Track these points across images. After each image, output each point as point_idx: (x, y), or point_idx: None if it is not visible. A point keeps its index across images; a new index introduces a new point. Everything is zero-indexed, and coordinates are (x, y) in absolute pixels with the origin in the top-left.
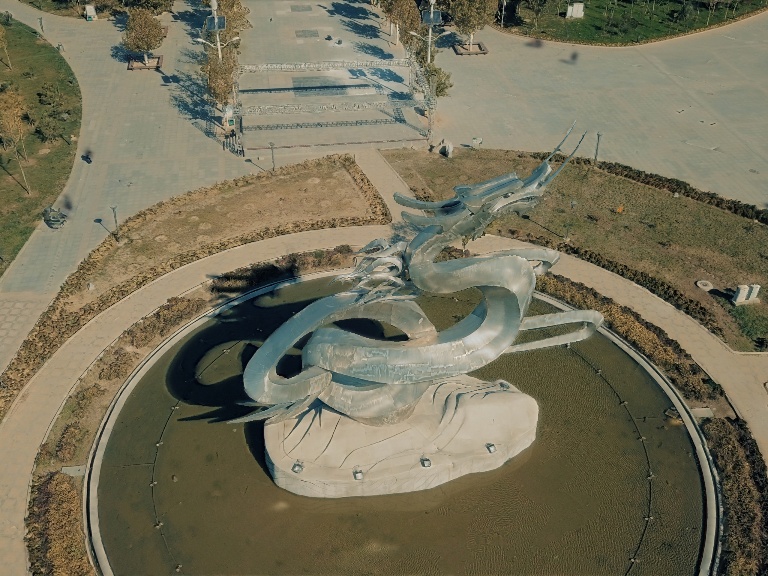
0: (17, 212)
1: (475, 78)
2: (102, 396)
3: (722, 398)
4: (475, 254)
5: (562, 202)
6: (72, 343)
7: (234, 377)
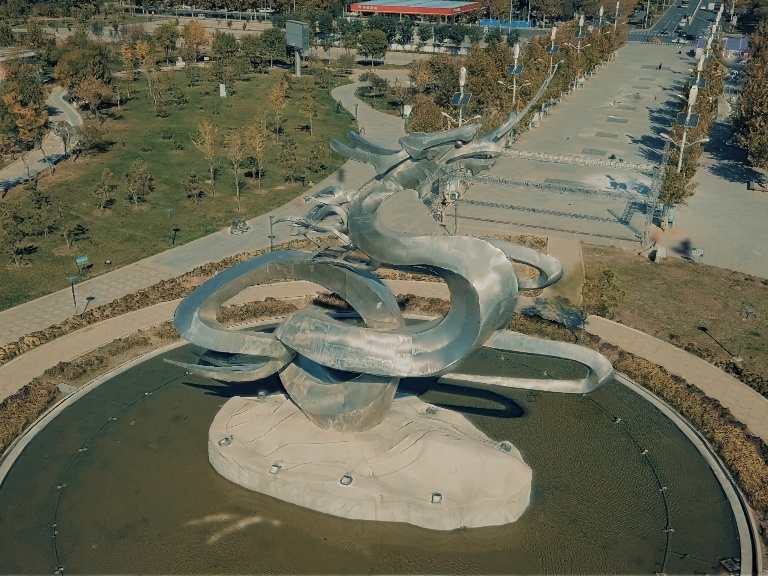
0: (217, 218)
1: (752, 210)
2: (144, 347)
3: None
4: (606, 343)
5: (764, 327)
6: (162, 306)
7: None
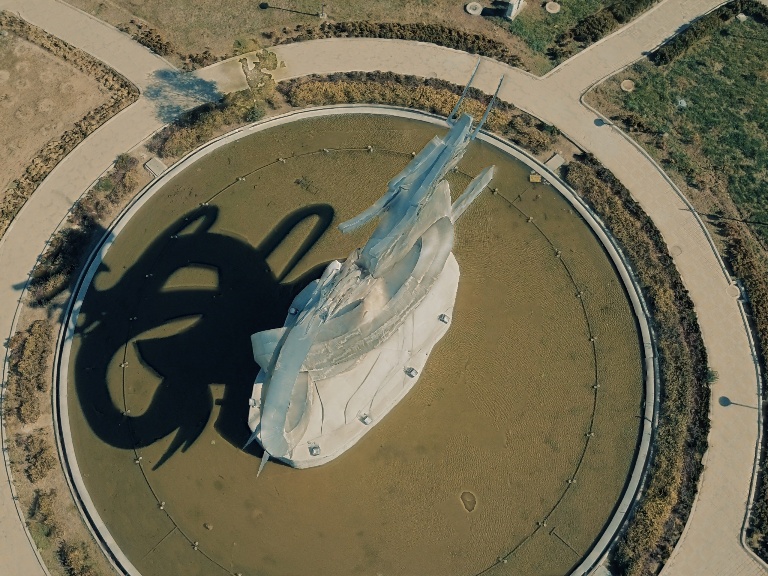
0: None
1: None
2: (56, 499)
3: (560, 137)
4: None
5: None
6: None
7: (159, 388)
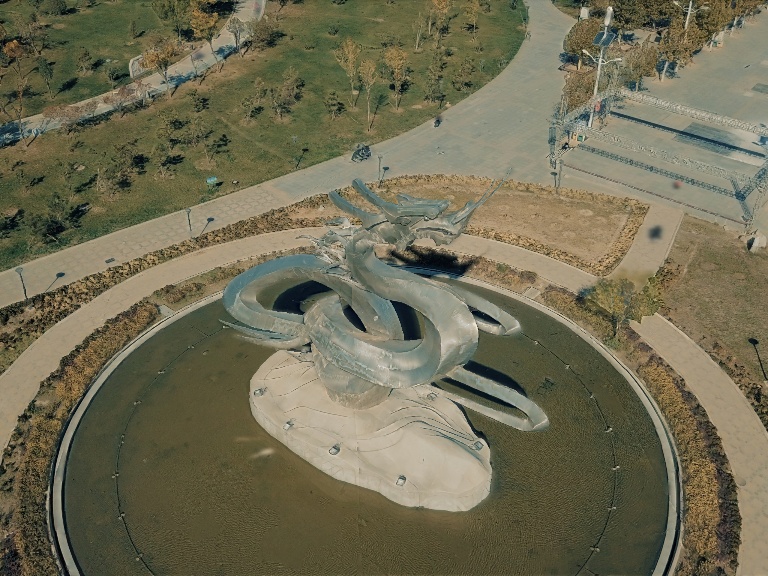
0: (346, 139)
1: None
2: None
3: None
4: (644, 342)
5: None
6: (265, 237)
7: None
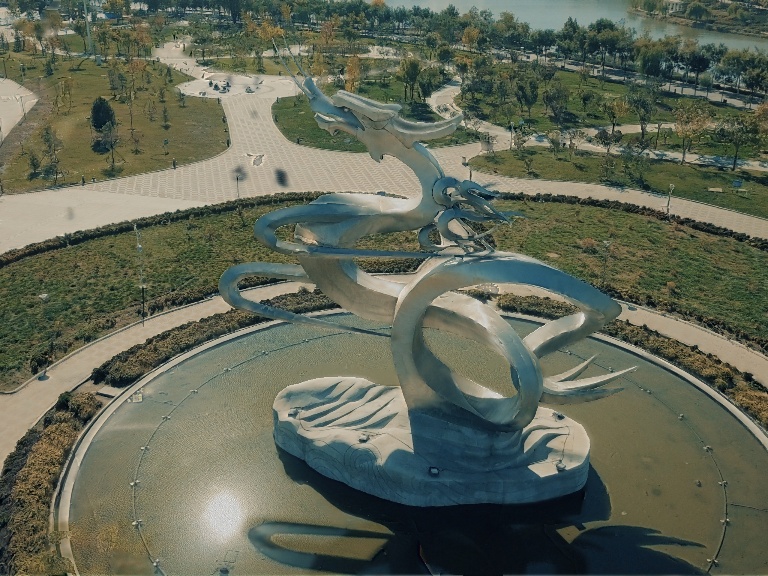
0: None
1: None
2: None
3: None
4: None
5: None
6: None
7: None
